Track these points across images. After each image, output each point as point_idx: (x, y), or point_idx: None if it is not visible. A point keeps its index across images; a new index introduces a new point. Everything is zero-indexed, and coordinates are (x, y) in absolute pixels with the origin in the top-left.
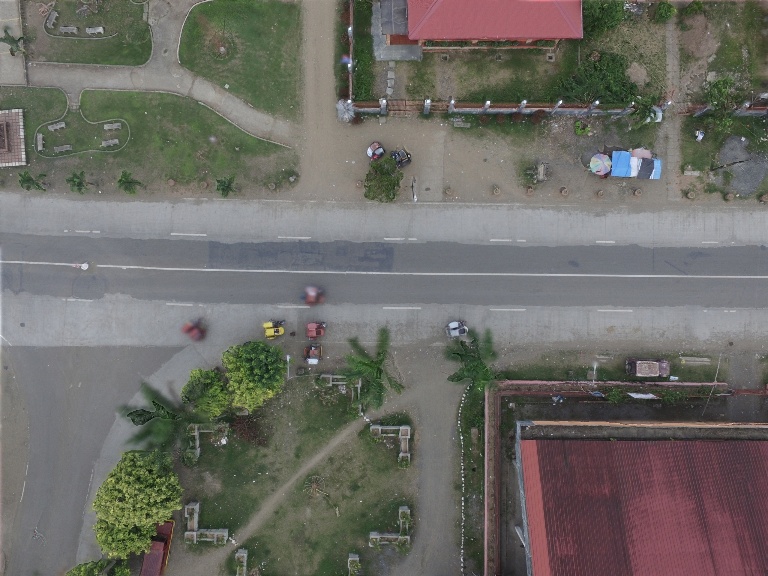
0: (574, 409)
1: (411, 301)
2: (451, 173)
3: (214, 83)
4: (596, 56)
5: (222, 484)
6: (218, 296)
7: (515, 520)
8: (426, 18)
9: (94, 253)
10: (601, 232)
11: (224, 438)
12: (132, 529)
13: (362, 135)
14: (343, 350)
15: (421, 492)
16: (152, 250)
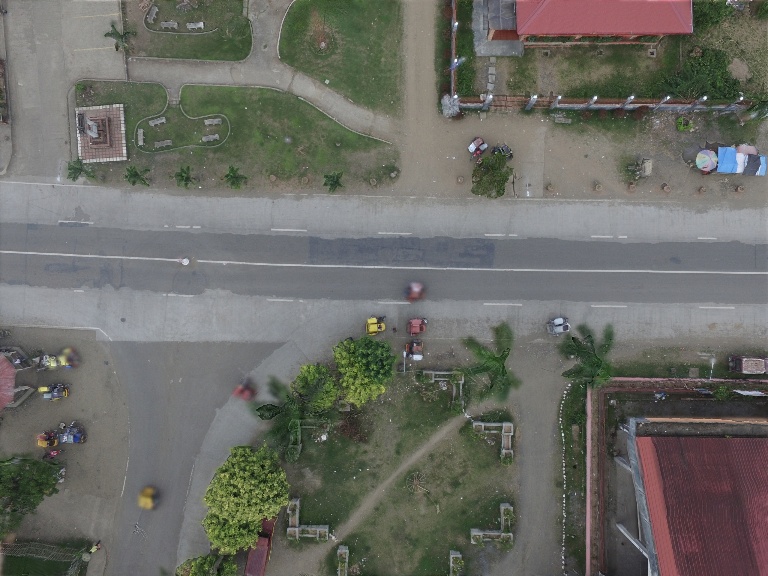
0: (676, 406)
1: (512, 297)
2: (552, 169)
3: (314, 78)
4: (698, 52)
5: (322, 480)
6: (318, 292)
7: (616, 518)
8: (537, 13)
9: (194, 248)
10: (702, 229)
11: (325, 434)
12: (242, 524)
13: (463, 131)
14: (443, 346)
15: (522, 489)
16: (252, 245)
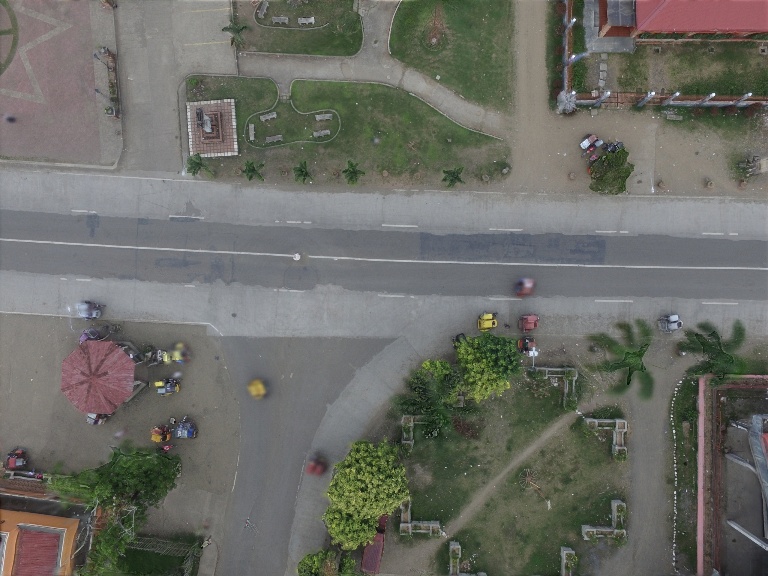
0: None
1: (623, 294)
2: (662, 166)
3: (425, 74)
4: None
5: (433, 476)
6: (430, 288)
7: (727, 514)
8: (659, 9)
9: (306, 244)
10: None
11: (436, 430)
12: (364, 520)
13: (574, 127)
14: (554, 343)
15: (633, 486)
16: (363, 241)
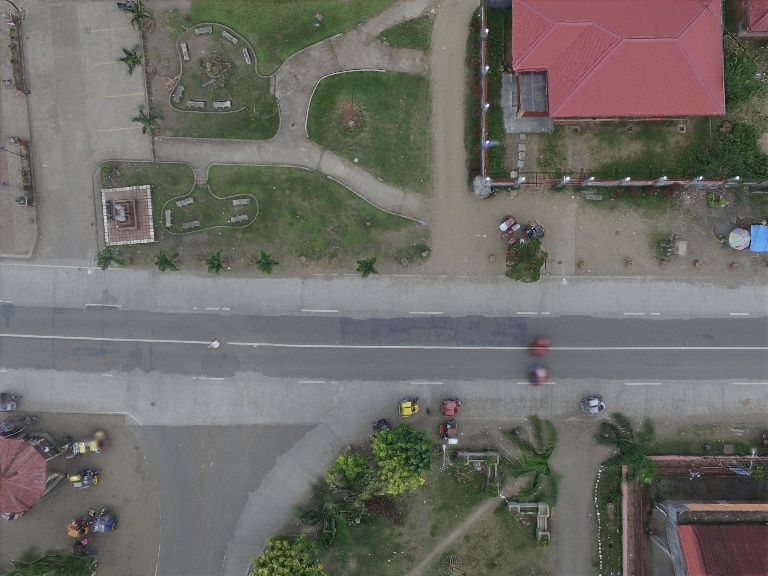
0: (710, 483)
1: (545, 376)
2: (583, 246)
3: (343, 157)
4: (728, 127)
5: (357, 563)
6: (350, 373)
7: None
8: (570, 97)
9: (224, 331)
10: (735, 304)
11: (359, 517)
12: None
13: (493, 208)
14: (477, 426)
15: (558, 569)
16: (283, 327)
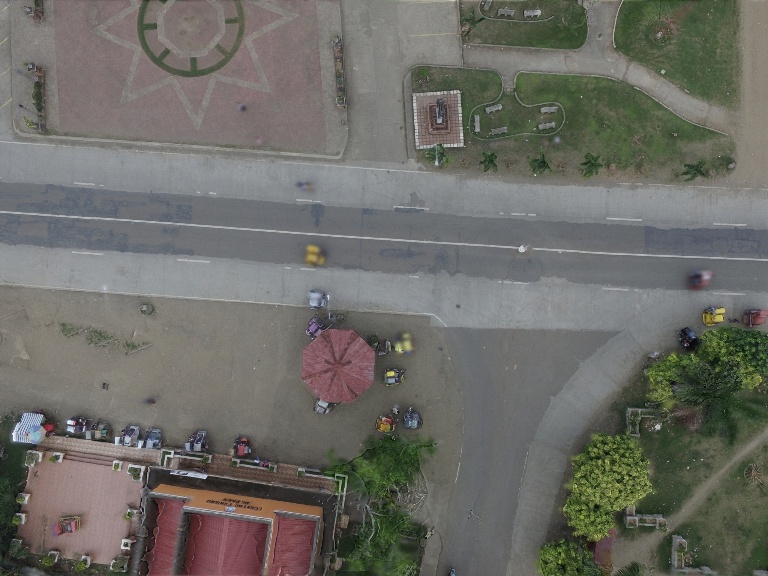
0: None
1: None
2: None
3: (649, 68)
4: None
5: (655, 470)
6: (654, 281)
7: None
8: None
9: (530, 236)
10: None
11: (660, 424)
12: None
13: None
14: None
15: None
16: (588, 234)
